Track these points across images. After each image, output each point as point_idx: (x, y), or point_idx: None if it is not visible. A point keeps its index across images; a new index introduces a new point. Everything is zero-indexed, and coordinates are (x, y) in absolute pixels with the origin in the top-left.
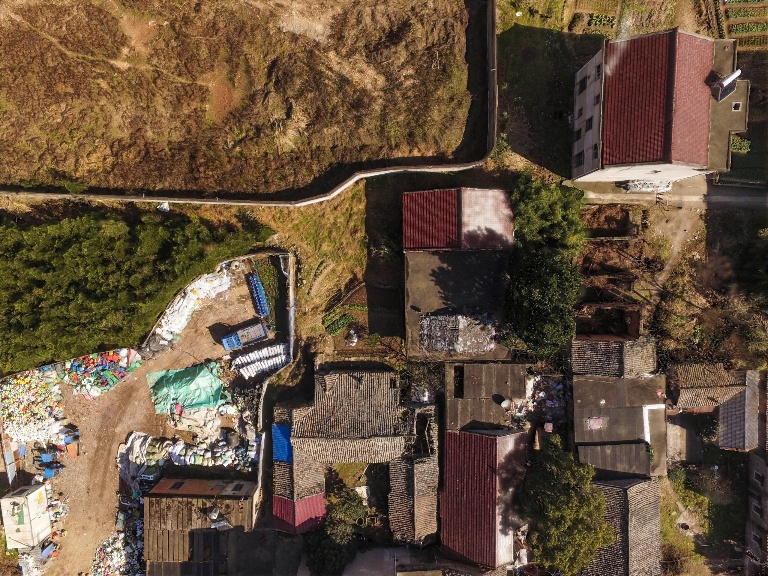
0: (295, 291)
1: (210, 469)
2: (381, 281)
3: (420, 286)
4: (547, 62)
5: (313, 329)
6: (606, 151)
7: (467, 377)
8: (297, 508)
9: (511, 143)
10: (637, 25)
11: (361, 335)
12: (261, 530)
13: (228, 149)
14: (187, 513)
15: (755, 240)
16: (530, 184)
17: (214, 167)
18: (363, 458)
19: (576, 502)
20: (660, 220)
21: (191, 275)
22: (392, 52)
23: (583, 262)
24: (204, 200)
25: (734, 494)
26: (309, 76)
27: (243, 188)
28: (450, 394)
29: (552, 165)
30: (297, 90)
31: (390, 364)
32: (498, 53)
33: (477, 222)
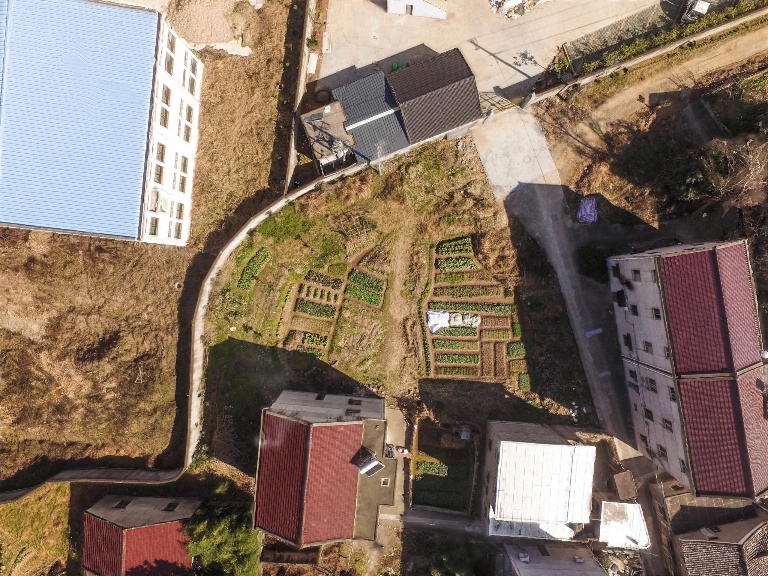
0: None
1: None
2: (82, 572)
3: None
4: (258, 376)
5: None
6: (259, 513)
7: None
8: None
9: (216, 452)
10: (349, 346)
11: None
12: None
13: None
14: None
15: None
16: (196, 527)
17: None
18: None
19: None
20: None
21: None
22: (94, 366)
23: (277, 574)
24: None
25: None
26: (18, 375)
27: None
28: None
29: None
30: (3, 390)
31: None
32: (211, 363)
33: (144, 557)
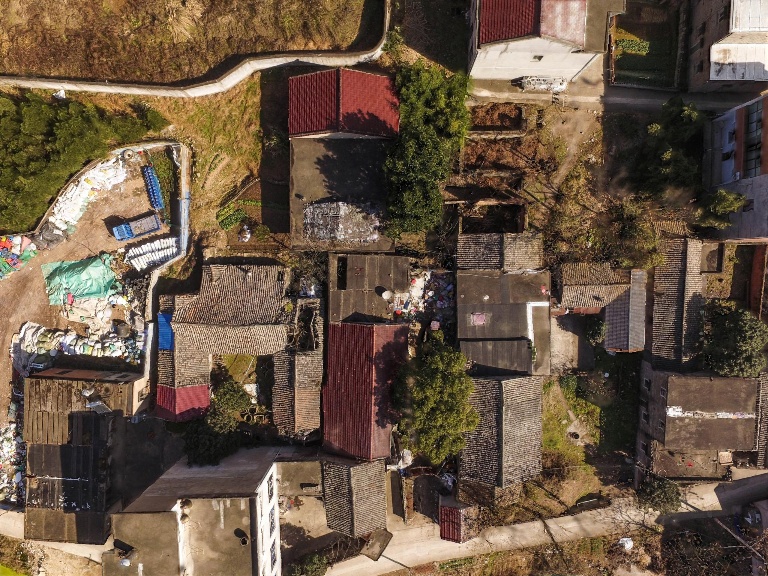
0: (190, 185)
1: (101, 361)
2: (275, 177)
3: (305, 174)
4: None
5: (207, 223)
6: (482, 30)
7: (350, 268)
8: (178, 396)
9: (406, 38)
10: None
11: (254, 231)
12: (150, 424)
13: (123, 36)
14: (67, 395)
15: (646, 138)
16: (410, 67)
17: (109, 54)
18: (247, 349)
19: (440, 383)
20: (556, 121)
21: (74, 153)
22: None
23: (476, 160)
24: (94, 83)
25: (626, 404)
26: None
27: (137, 76)
28: (333, 285)
29: (449, 63)
30: None
31: (282, 261)
32: None
33: (358, 105)
